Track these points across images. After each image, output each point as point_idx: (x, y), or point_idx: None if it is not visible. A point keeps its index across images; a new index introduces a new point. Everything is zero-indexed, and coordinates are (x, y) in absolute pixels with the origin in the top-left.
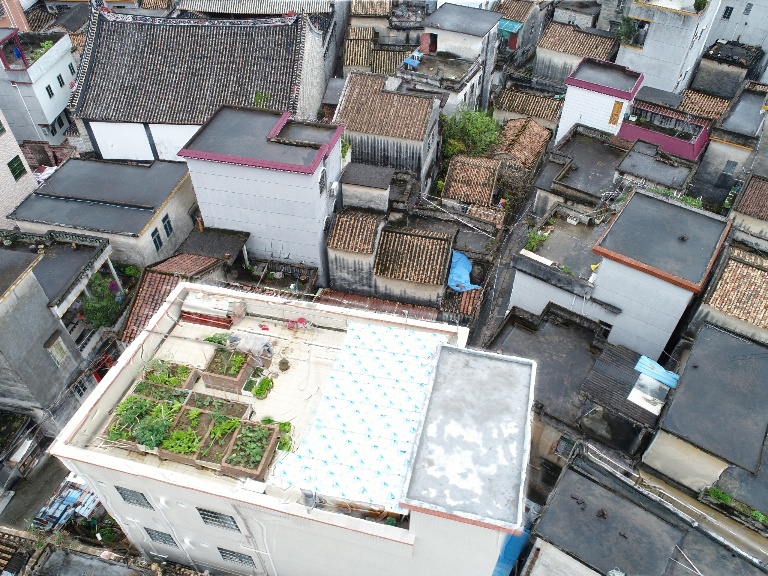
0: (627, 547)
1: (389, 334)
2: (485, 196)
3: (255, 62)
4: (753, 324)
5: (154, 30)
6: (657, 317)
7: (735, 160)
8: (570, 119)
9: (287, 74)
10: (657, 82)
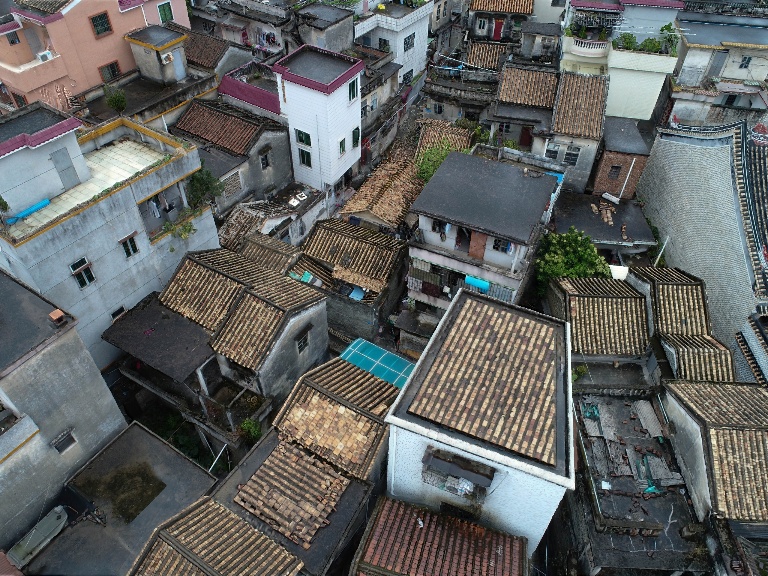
0: None
1: None
2: None
3: None
4: None
5: None
6: None
7: None
8: None
9: None
10: None
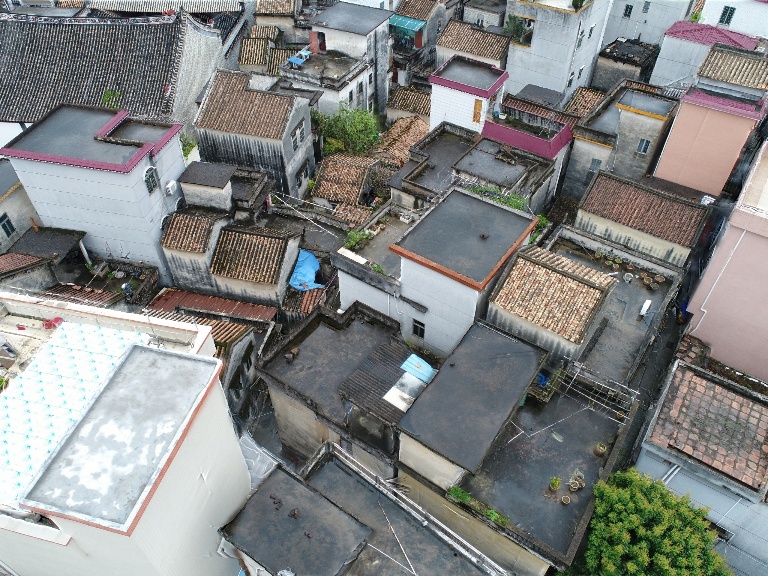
0: (307, 547)
1: (96, 333)
2: (353, 195)
3: (135, 61)
4: (532, 322)
5: (35, 29)
6: (456, 315)
7: (599, 158)
8: (438, 117)
9: (166, 73)
10: (547, 80)
